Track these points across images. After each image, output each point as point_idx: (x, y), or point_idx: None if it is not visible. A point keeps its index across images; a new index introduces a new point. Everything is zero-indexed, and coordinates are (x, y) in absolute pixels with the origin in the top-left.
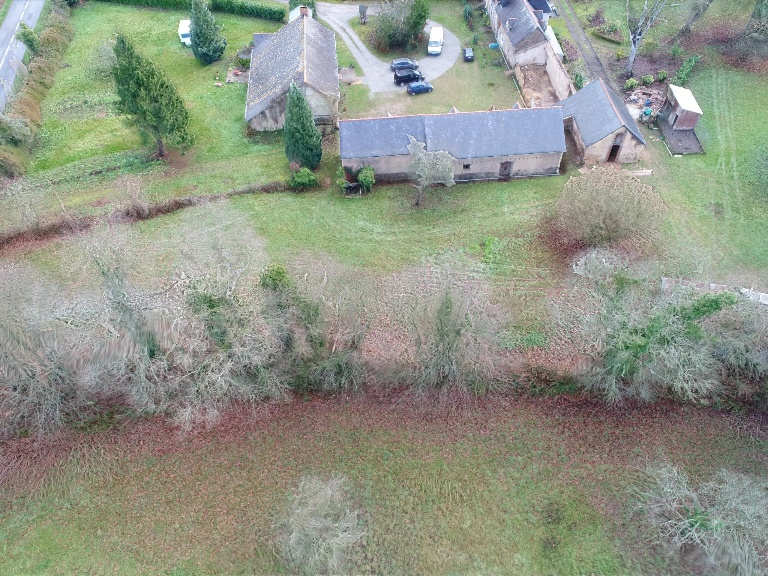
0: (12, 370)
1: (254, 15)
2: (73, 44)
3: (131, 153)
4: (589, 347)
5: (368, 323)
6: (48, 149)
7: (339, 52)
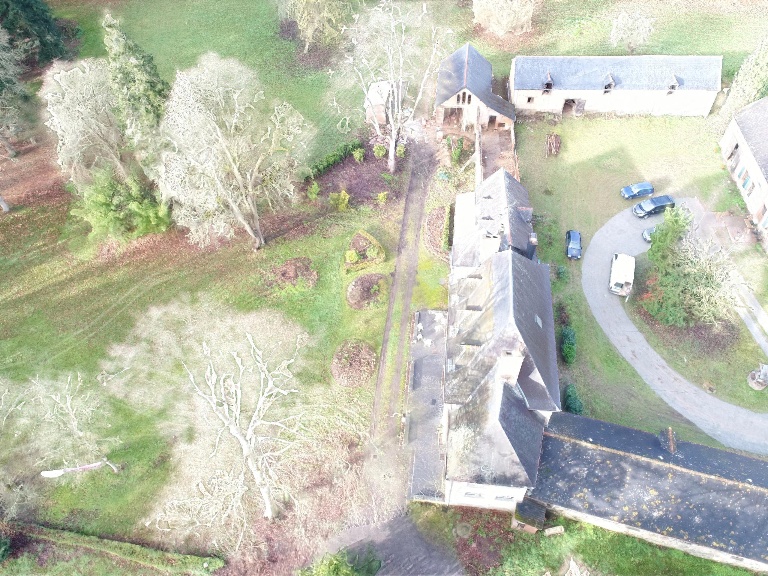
0: None
1: None
2: None
3: None
4: None
5: (654, 2)
6: None
7: None
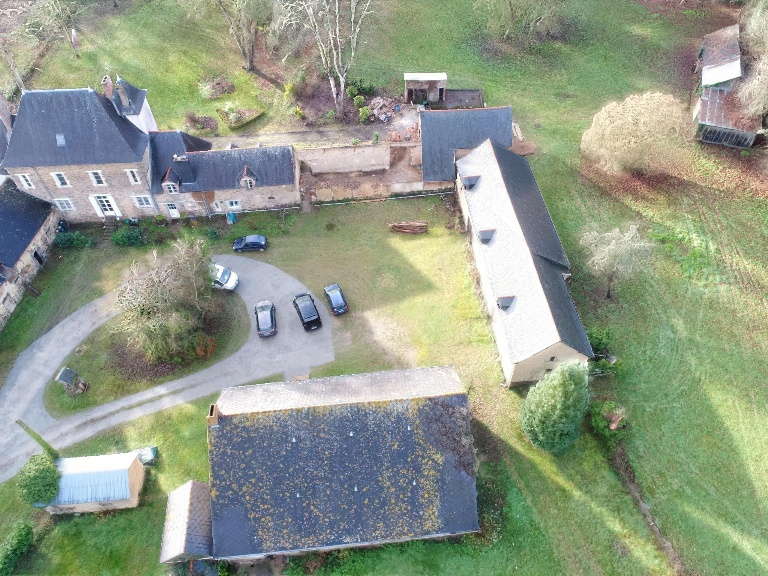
0: None
1: None
2: None
3: None
4: None
5: None
6: None
7: (187, 420)
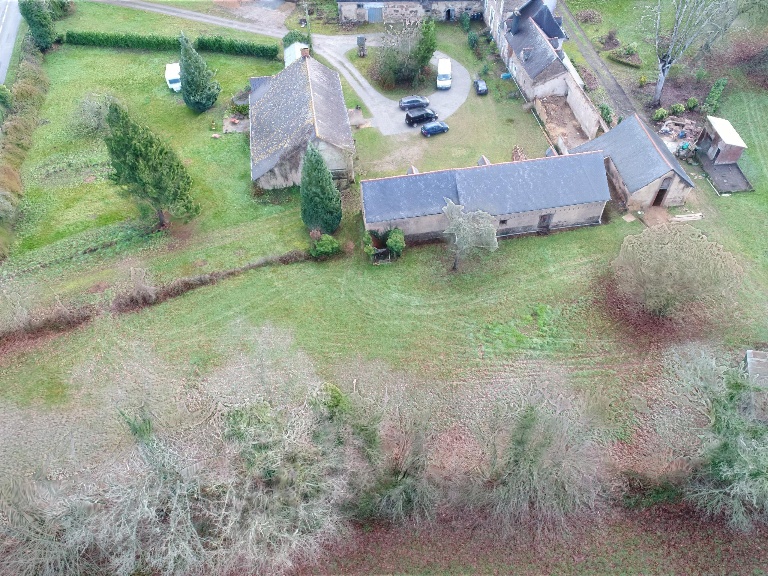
0: (16, 516)
1: (245, 53)
2: (49, 96)
3: (127, 224)
4: (691, 452)
5: None
6: (33, 224)
7: None
